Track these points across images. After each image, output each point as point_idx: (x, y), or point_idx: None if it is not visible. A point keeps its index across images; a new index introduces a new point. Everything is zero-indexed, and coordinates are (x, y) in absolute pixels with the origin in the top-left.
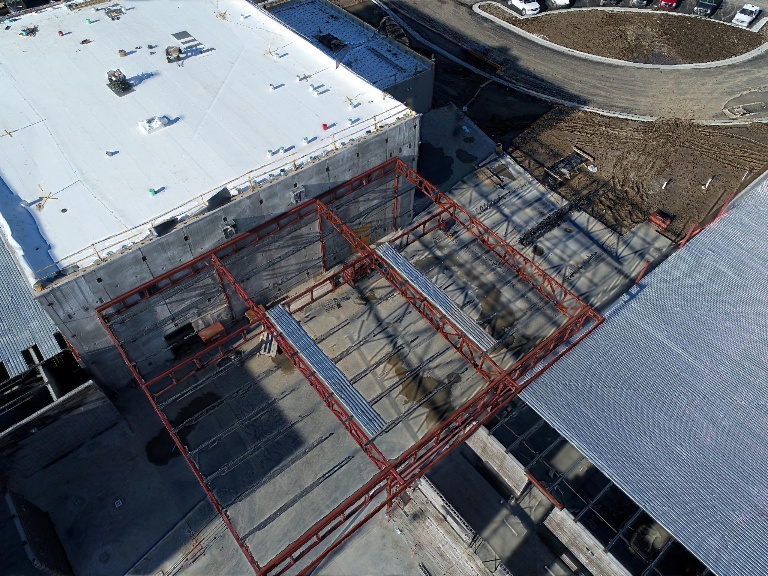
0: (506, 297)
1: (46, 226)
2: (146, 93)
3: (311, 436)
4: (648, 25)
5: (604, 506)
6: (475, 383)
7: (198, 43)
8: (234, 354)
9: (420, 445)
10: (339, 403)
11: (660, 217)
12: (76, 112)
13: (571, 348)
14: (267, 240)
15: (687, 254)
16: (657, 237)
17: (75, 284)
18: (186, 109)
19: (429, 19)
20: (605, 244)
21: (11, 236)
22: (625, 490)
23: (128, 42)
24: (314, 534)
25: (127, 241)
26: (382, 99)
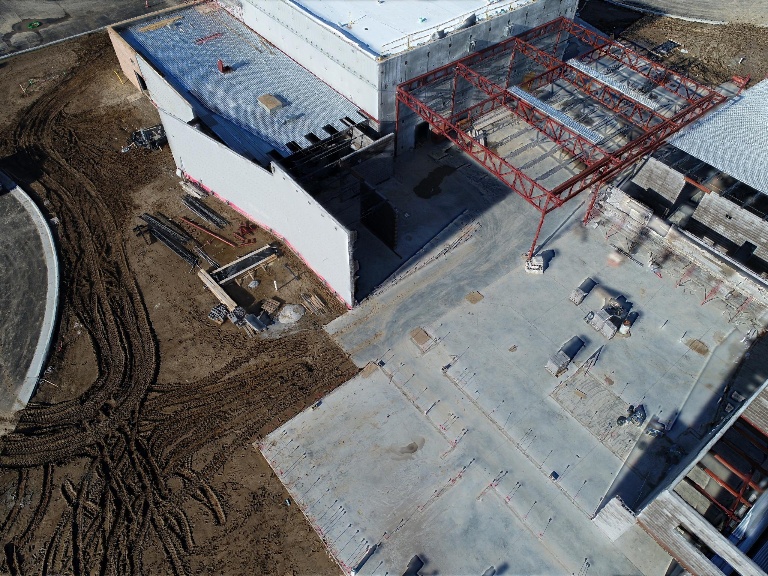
0: None
1: (359, 36)
2: None
3: None
4: None
5: (735, 196)
6: None
7: None
8: (461, 140)
9: (626, 147)
10: (569, 129)
11: (741, 77)
12: None
13: (708, 109)
14: None
15: None
16: None
17: (396, 61)
18: None
19: None
20: (702, 93)
21: None
22: (749, 184)
23: None
24: (573, 183)
25: (416, 43)
26: None
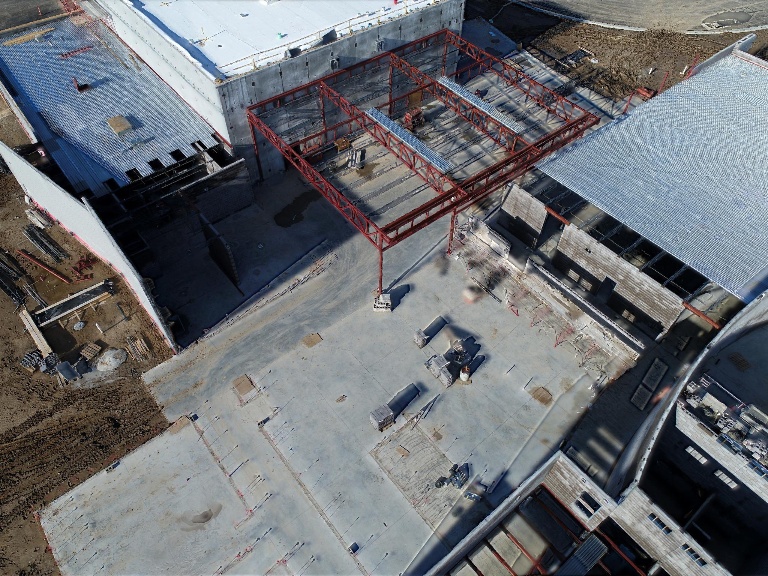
0: (527, 138)
1: (210, 54)
2: None
3: (390, 213)
4: None
5: (598, 227)
6: None
7: None
8: None
9: (477, 177)
10: (421, 157)
11: (646, 89)
12: None
13: (577, 133)
14: (359, 74)
15: (663, 98)
16: None
17: (240, 83)
18: None
19: None
20: (603, 107)
21: (191, 56)
22: (612, 215)
23: None
24: (412, 218)
25: None
26: None
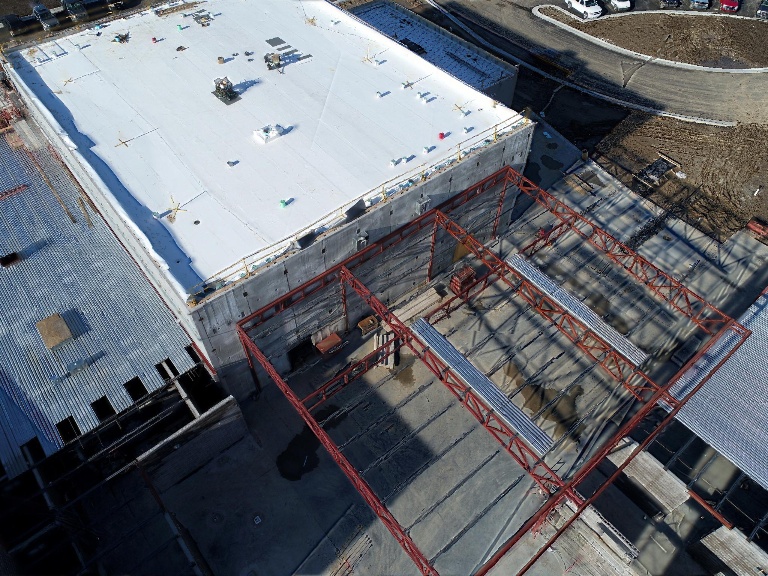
0: (615, 307)
1: (182, 238)
2: (253, 101)
3: None
4: (711, 28)
5: None
6: (598, 395)
7: (294, 50)
8: None
9: (592, 463)
10: (501, 420)
11: (759, 225)
12: (187, 121)
13: (724, 362)
14: None
15: None
16: (758, 245)
17: (225, 299)
18: (297, 118)
19: (490, 23)
20: (706, 252)
21: (153, 249)
22: None
23: (223, 49)
24: None
25: None
26: (492, 107)
